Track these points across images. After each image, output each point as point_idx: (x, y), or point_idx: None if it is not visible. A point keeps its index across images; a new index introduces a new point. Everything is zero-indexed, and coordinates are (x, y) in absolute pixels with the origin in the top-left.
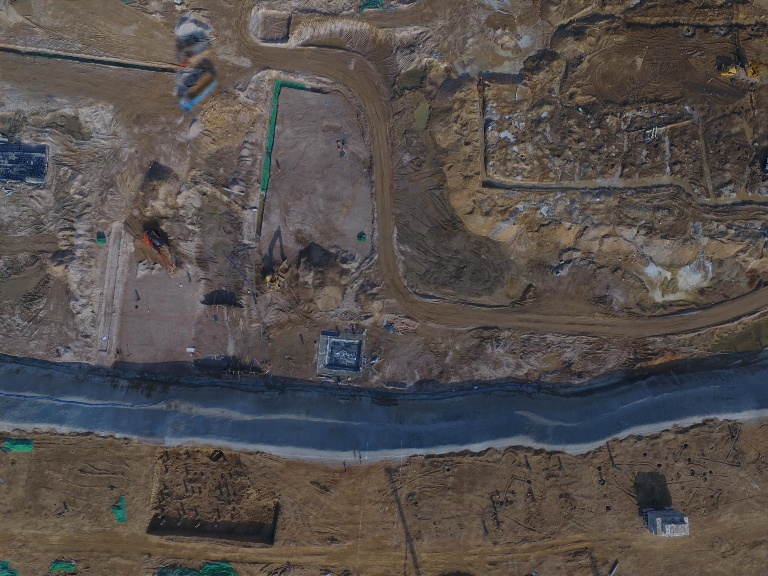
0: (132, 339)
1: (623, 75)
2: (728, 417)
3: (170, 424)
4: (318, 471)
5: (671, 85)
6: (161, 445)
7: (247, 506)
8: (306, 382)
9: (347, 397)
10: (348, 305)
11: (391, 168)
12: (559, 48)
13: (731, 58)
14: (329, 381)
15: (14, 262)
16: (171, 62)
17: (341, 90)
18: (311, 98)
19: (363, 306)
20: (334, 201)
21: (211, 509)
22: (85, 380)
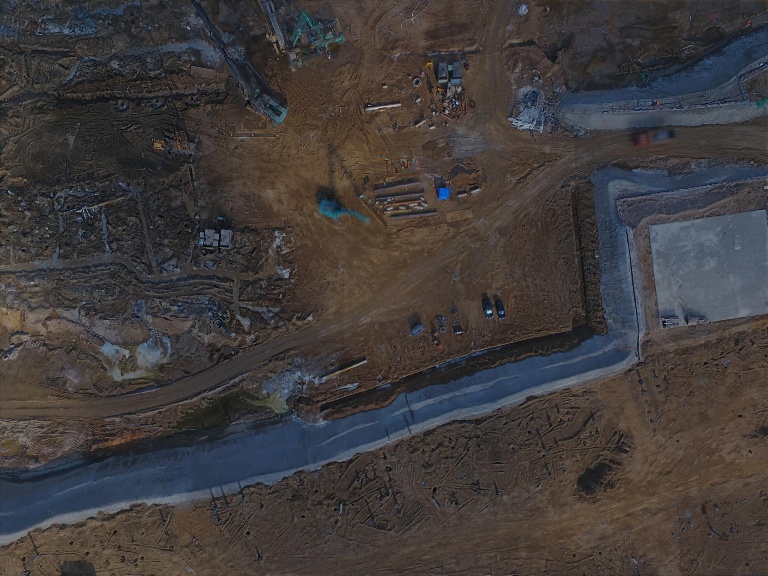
0: None
1: (55, 154)
2: (157, 501)
3: None
4: None
5: (105, 162)
6: None
7: None
8: None
9: None
10: None
11: None
12: None
13: (170, 130)
14: None
15: None
16: None
17: None
18: None
19: None
20: None
21: None
22: None
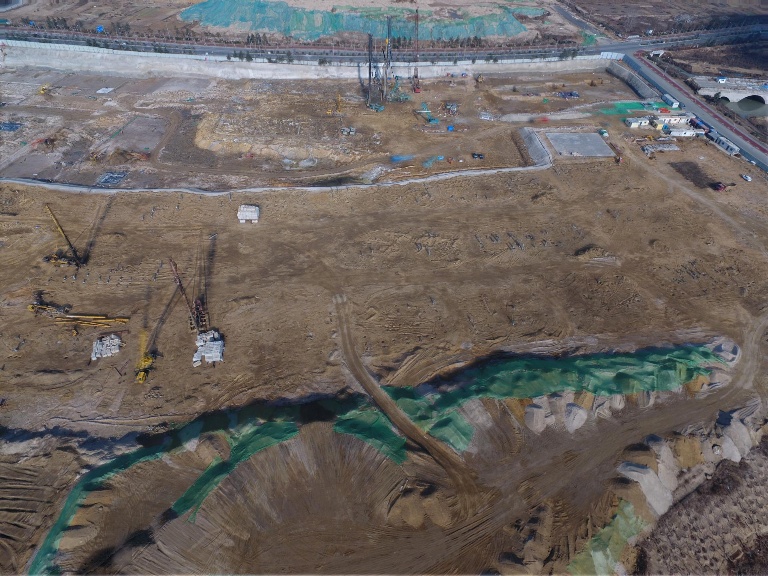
0: None
1: None
2: (302, 188)
3: None
4: None
5: None
6: None
7: None
8: None
9: None
10: None
11: (173, 134)
12: (260, 109)
13: None
14: None
15: None
16: (96, 109)
17: (163, 118)
18: (149, 119)
19: (133, 164)
20: None
21: None
22: None
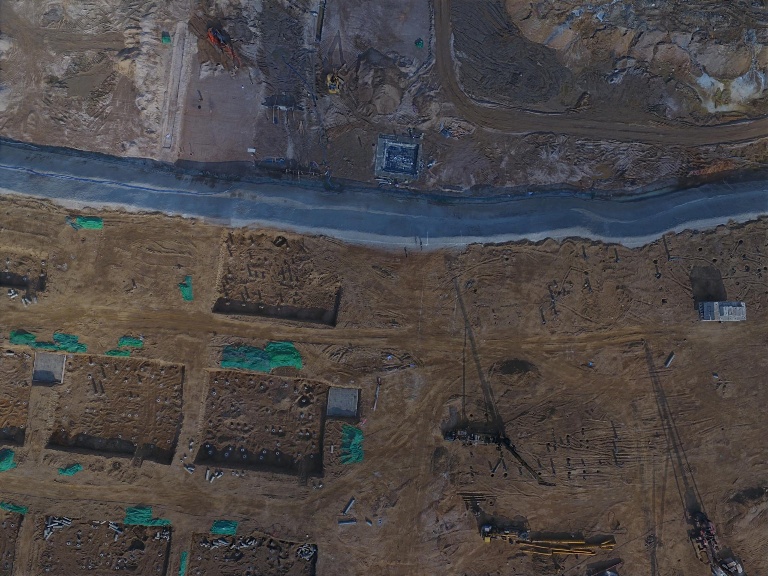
0: (195, 138)
1: None
2: None
3: (235, 208)
4: (380, 256)
5: None
6: (227, 226)
7: (309, 292)
8: (364, 184)
9: (404, 199)
10: (406, 109)
11: None
12: None
13: None
14: (387, 183)
15: (82, 59)
16: None
17: None
18: None
19: (421, 109)
20: (392, 8)
21: (274, 294)
22: (150, 172)
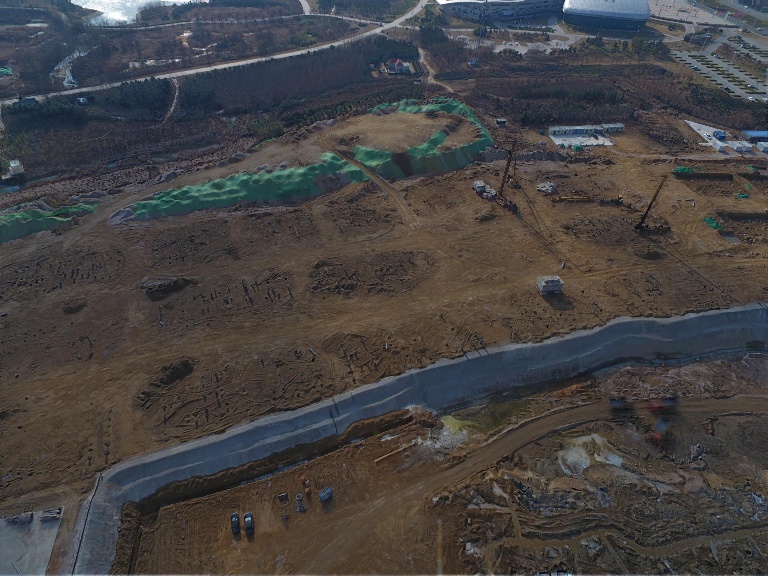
0: None
1: None
2: (525, 345)
3: None
4: None
5: None
6: None
7: None
8: None
9: None
10: None
11: None
12: None
13: None
14: None
15: None
16: None
17: None
18: None
19: None
20: None
21: None
22: None
